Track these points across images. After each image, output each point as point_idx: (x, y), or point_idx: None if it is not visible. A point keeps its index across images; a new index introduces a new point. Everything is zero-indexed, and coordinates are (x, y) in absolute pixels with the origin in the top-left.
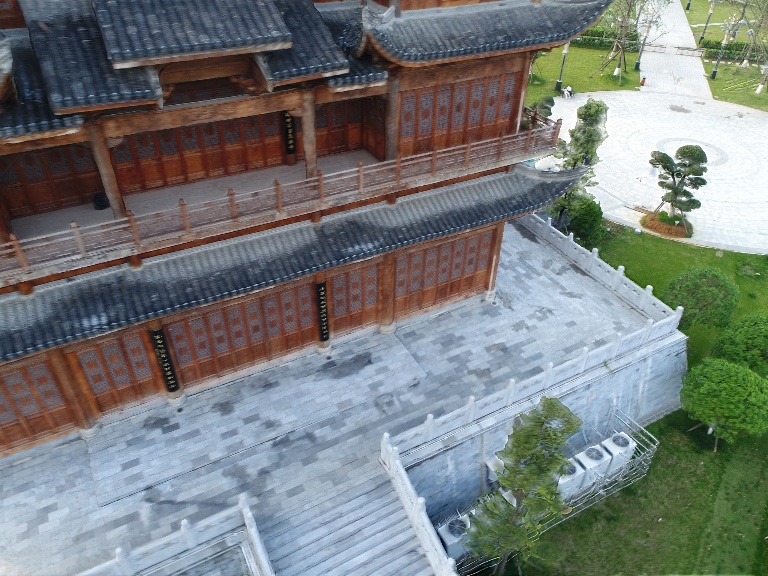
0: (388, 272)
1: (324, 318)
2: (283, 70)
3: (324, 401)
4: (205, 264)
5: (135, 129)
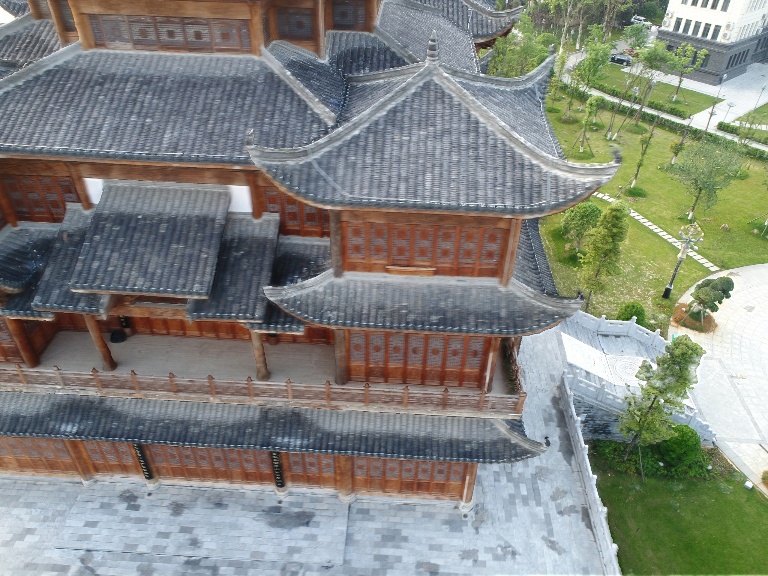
0: (342, 456)
1: (277, 471)
2: (204, 311)
3: (245, 543)
4: (163, 410)
5: (114, 313)
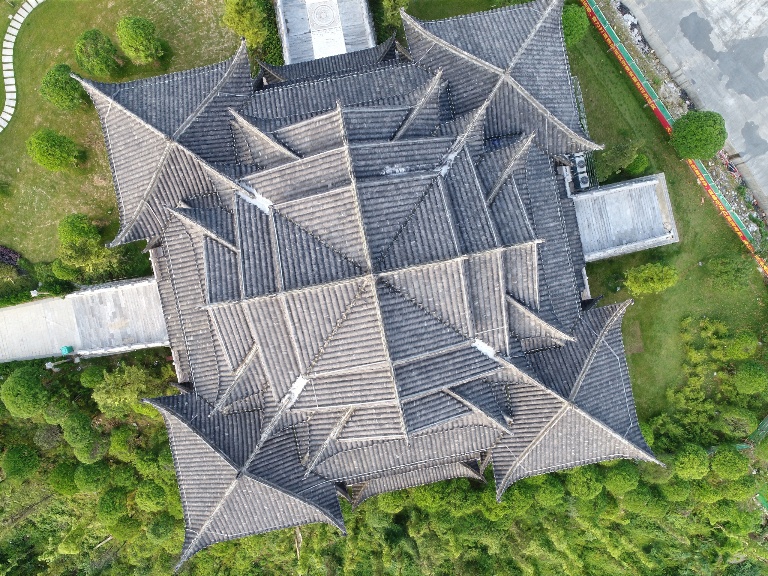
0: None
1: None
2: None
3: None
4: None
5: None
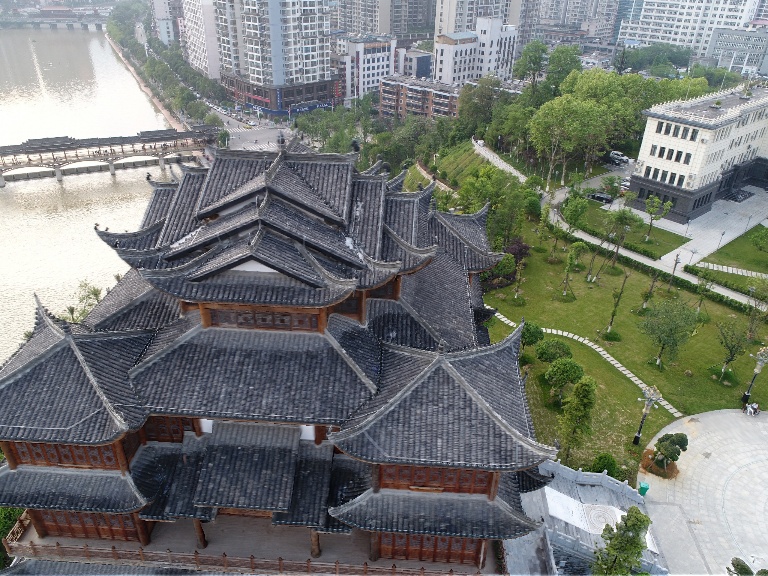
0: None
1: None
2: (283, 519)
3: None
4: None
5: None
